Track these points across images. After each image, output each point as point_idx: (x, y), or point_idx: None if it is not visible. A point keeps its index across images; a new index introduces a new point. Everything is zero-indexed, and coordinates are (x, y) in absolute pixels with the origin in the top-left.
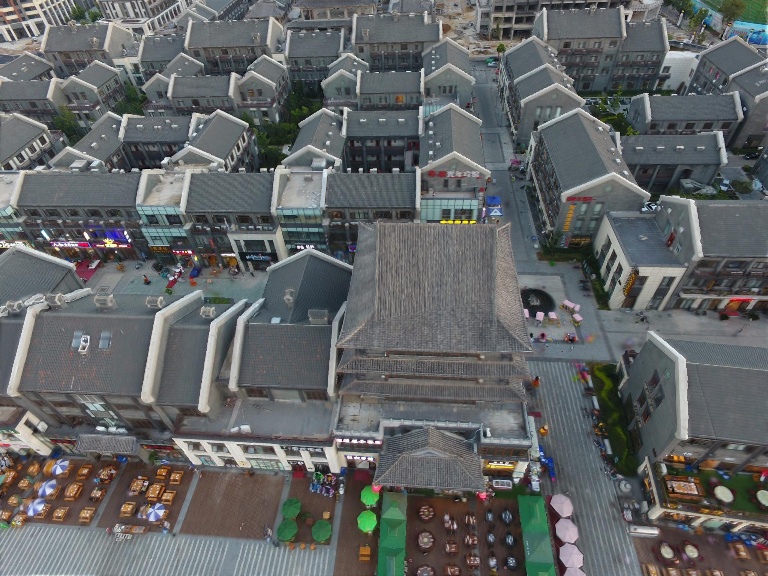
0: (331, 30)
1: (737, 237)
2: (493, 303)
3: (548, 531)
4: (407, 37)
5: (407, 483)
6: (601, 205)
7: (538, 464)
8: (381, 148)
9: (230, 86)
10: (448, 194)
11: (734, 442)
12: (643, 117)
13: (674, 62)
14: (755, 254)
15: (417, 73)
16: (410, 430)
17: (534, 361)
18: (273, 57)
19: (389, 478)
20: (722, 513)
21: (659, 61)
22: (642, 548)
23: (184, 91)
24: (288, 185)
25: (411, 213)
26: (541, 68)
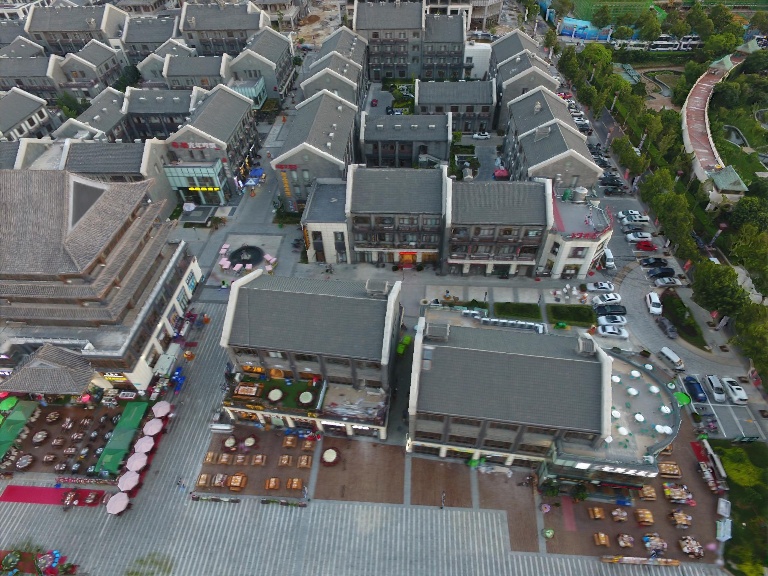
0: (168, 17)
1: (383, 197)
2: (62, 235)
3: (136, 427)
4: (231, 25)
5: (23, 389)
6: (307, 172)
7: (166, 380)
8: (162, 124)
9: (48, 67)
10: (195, 164)
11: (264, 349)
12: (414, 101)
13: (474, 53)
14: (394, 211)
15: (220, 58)
16: (37, 348)
17: (217, 303)
18: (110, 42)
19: (9, 385)
20: (265, 408)
21: (461, 52)
22: (216, 441)
23: (7, 71)
24: (45, 153)
25: (142, 178)
26: (329, 55)
